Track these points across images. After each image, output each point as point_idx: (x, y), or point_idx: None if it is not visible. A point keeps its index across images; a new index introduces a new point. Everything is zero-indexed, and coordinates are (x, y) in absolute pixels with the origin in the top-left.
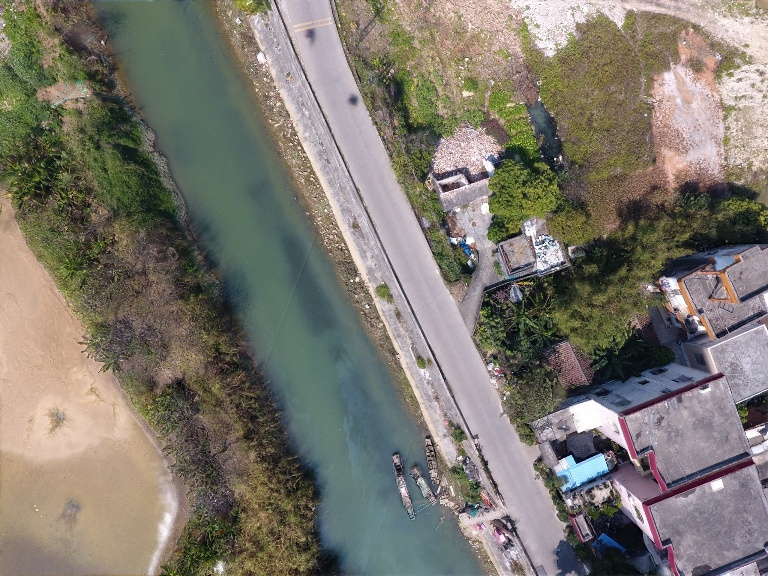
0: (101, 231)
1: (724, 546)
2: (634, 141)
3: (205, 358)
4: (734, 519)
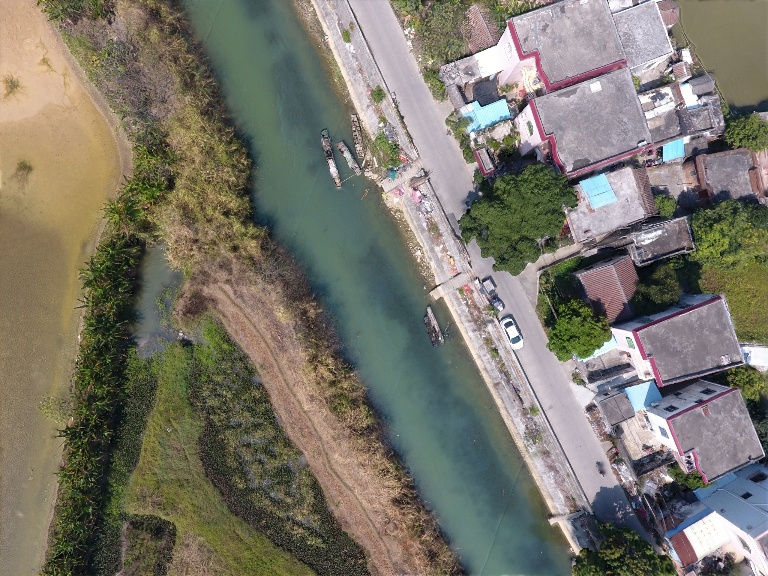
0: None
1: (602, 142)
2: None
3: (144, 2)
4: (611, 119)
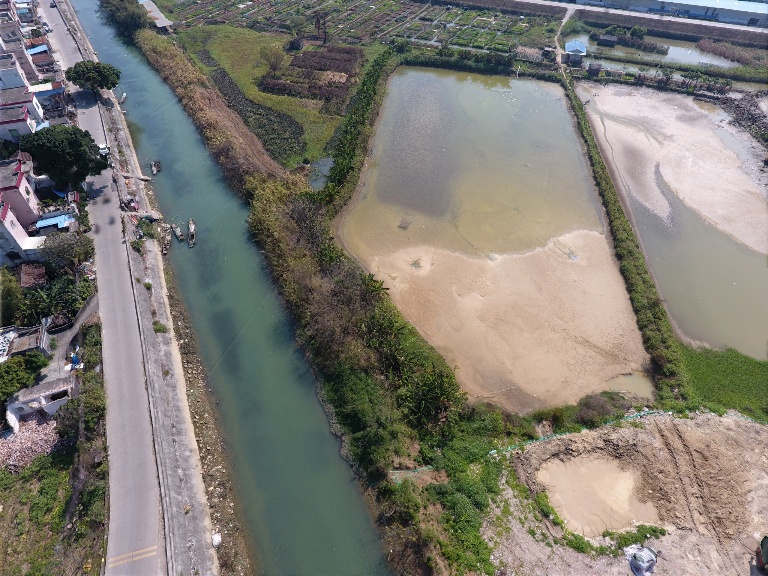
0: None
1: None
2: None
3: None
4: None
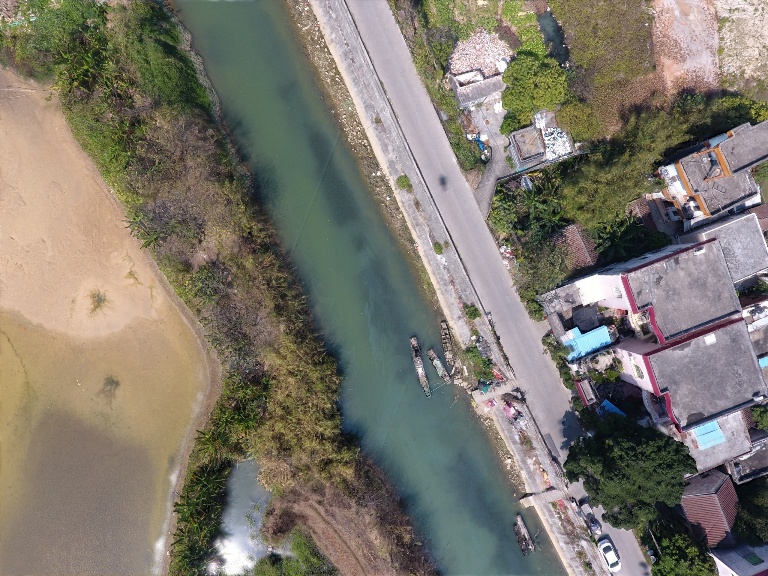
0: (144, 116)
1: (716, 395)
2: (636, 48)
3: (240, 233)
4: (725, 371)
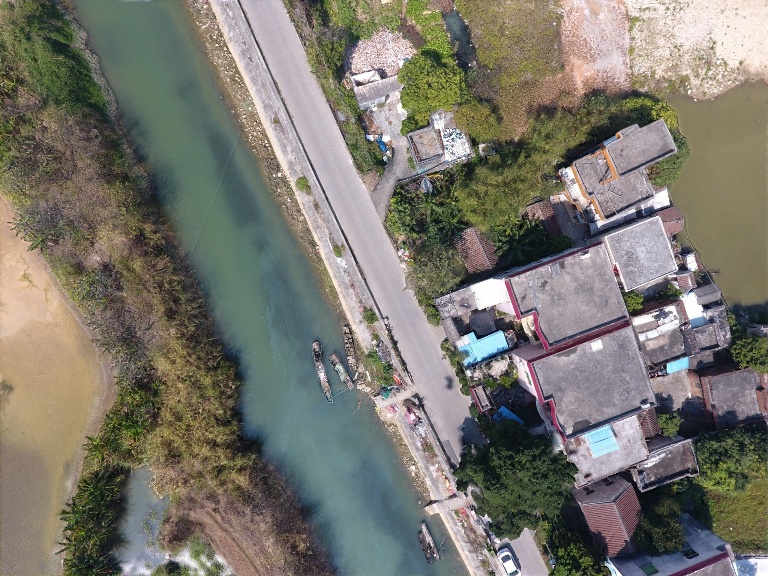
0: (30, 116)
1: (603, 403)
2: (543, 48)
3: (127, 236)
4: (613, 378)
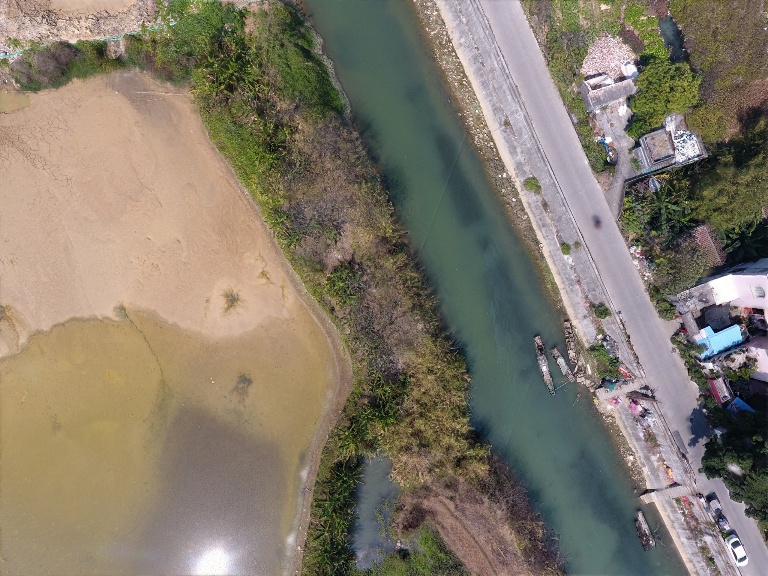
0: (287, 119)
1: None
2: (755, 52)
3: (383, 234)
4: None
